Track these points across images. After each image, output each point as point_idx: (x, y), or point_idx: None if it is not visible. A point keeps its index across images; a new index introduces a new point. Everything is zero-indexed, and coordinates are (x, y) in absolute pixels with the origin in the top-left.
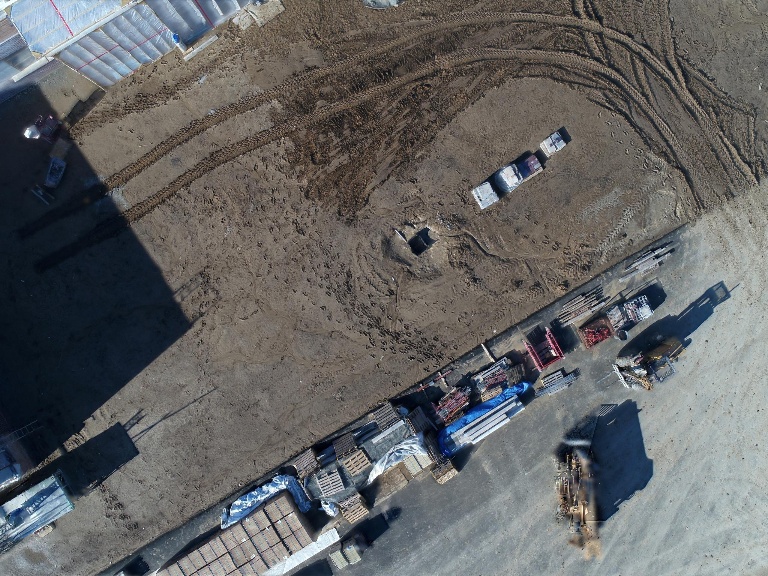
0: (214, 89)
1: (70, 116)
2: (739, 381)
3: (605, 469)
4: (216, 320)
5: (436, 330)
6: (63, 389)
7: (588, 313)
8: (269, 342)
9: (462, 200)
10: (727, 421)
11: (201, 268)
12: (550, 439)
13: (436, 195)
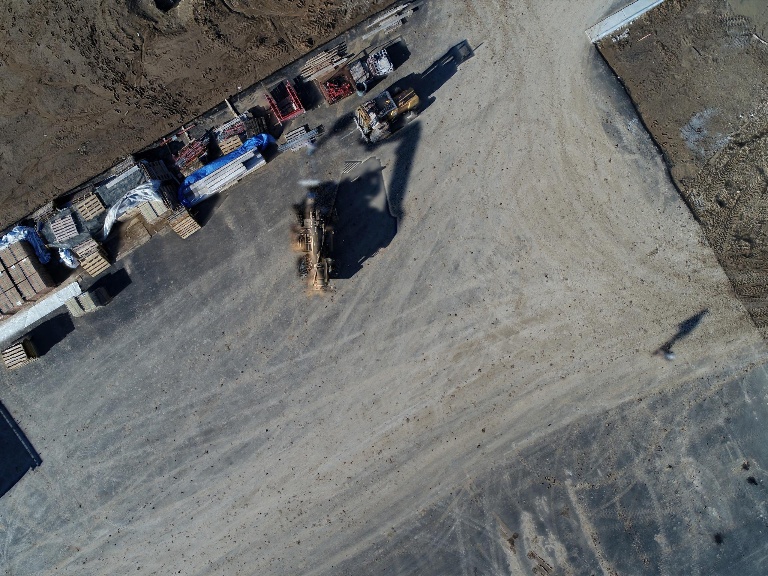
0: None
1: None
2: (483, 140)
3: (349, 226)
4: None
5: (181, 86)
6: None
7: (330, 68)
8: (13, 95)
9: None
10: (471, 180)
11: None
12: (294, 196)
13: None
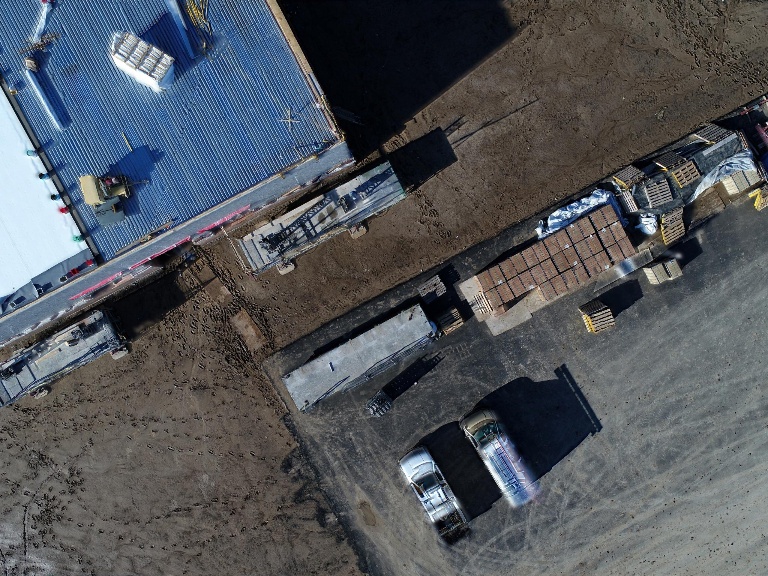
0: None
1: None
2: None
3: None
4: (544, 29)
5: (762, 54)
6: (387, 89)
7: None
8: (595, 55)
9: None
10: None
11: None
12: None
13: None
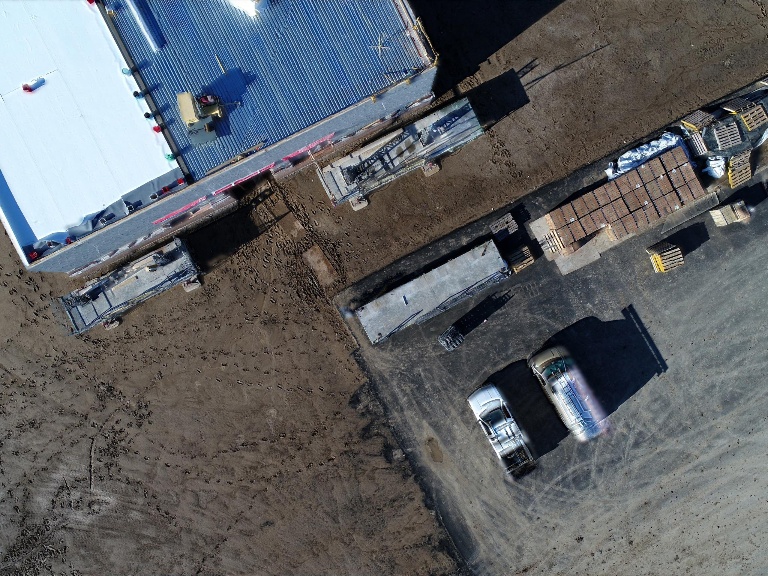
0: None
1: None
2: None
3: None
4: None
5: None
6: (462, 30)
7: None
8: (665, 3)
9: None
10: None
11: None
12: None
13: None
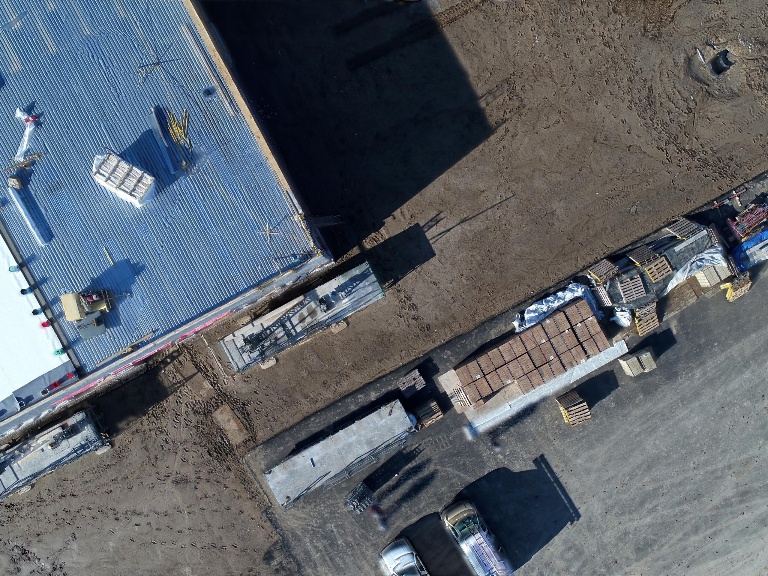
0: None
1: None
2: None
3: None
4: (519, 127)
5: (731, 150)
6: (366, 186)
7: None
8: (569, 152)
9: (764, 23)
10: None
11: (507, 75)
12: None
13: (739, 17)
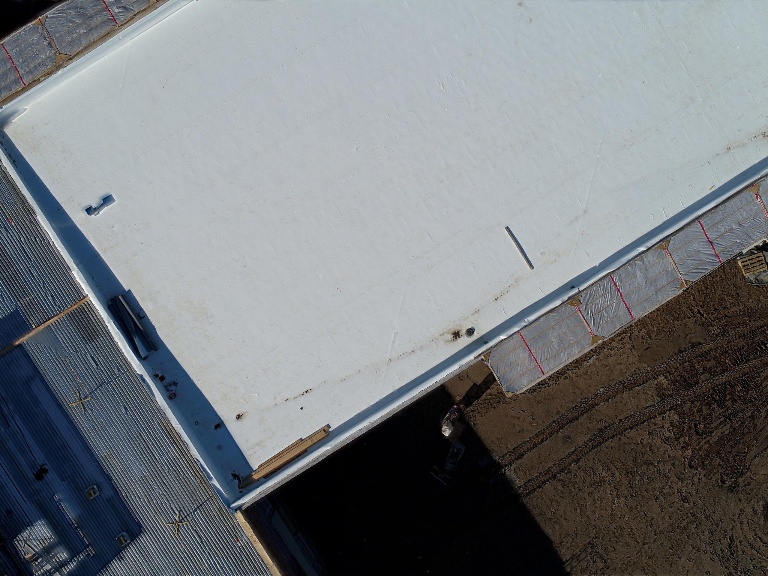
0: (603, 368)
1: (465, 399)
2: None
3: None
4: None
5: None
6: None
7: None
8: None
9: None
10: None
11: (589, 538)
12: None
13: None
